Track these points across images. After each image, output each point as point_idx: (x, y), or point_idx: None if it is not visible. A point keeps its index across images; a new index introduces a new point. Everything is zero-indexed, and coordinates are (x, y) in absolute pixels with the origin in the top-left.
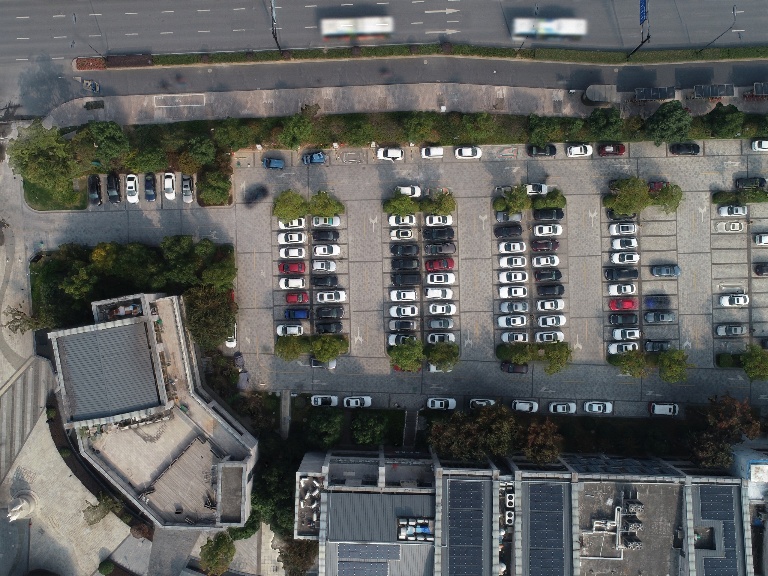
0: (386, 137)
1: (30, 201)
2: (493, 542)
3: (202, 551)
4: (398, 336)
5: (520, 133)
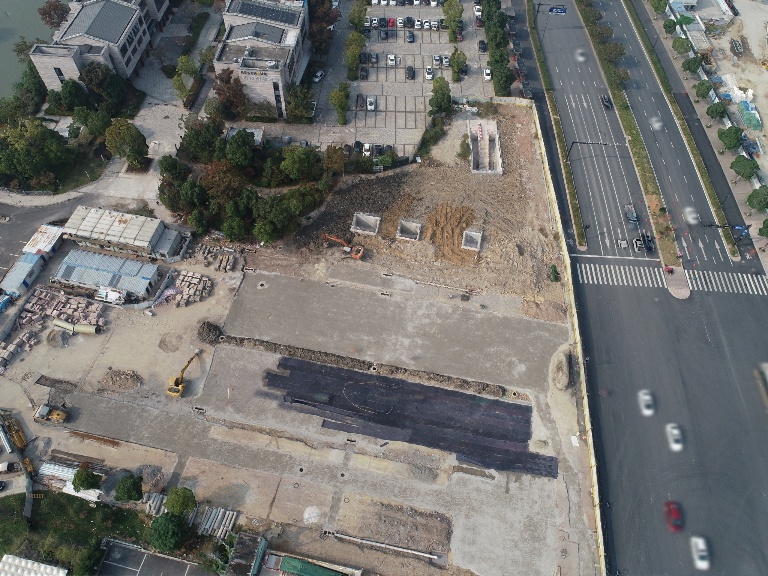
0: None
1: None
2: None
3: None
4: None
5: None
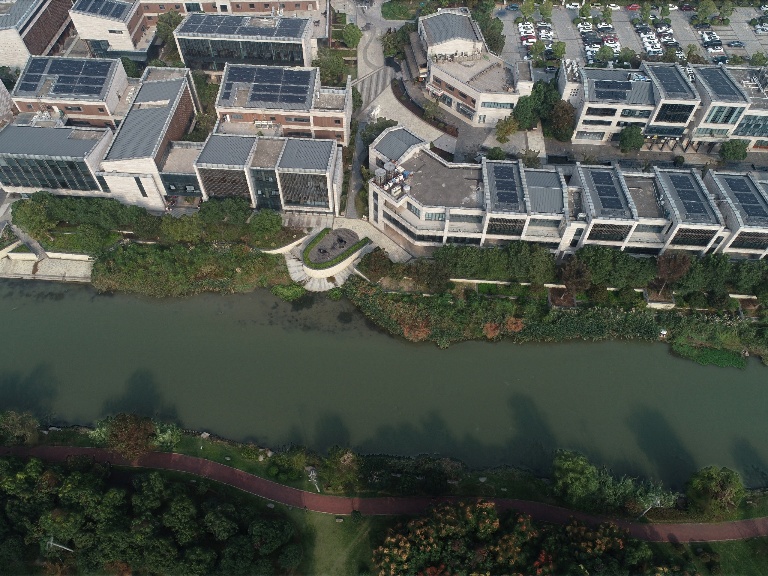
0: (569, 2)
1: (385, 17)
2: (686, 80)
3: (498, 121)
4: (594, 60)
5: (638, 3)
